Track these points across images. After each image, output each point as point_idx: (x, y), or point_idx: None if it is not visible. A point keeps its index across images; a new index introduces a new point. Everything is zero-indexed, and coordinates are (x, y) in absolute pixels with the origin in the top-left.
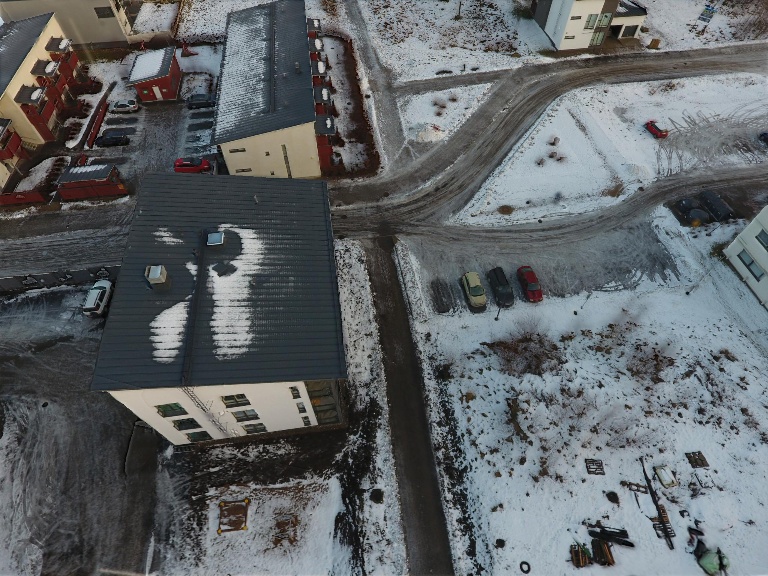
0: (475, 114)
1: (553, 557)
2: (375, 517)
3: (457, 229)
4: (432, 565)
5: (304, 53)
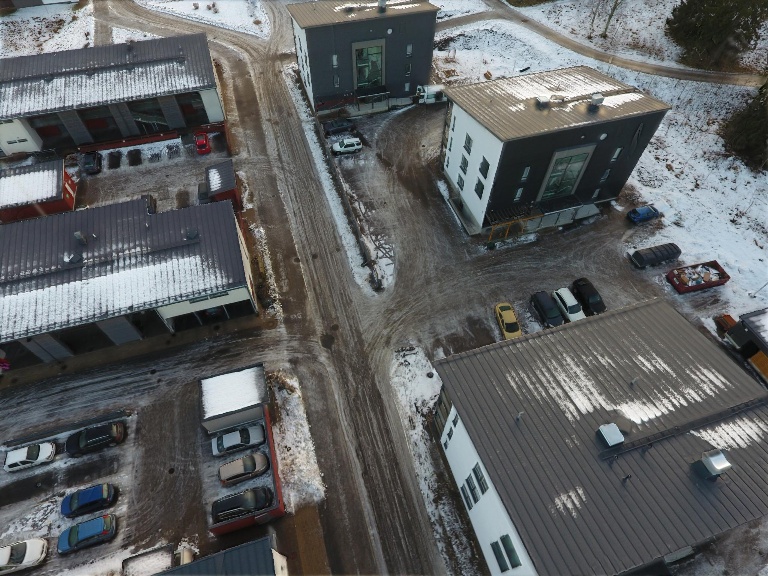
0: (153, 33)
1: (437, 2)
2: (438, 38)
3: (273, 36)
4: (449, 24)
5: (99, 49)
